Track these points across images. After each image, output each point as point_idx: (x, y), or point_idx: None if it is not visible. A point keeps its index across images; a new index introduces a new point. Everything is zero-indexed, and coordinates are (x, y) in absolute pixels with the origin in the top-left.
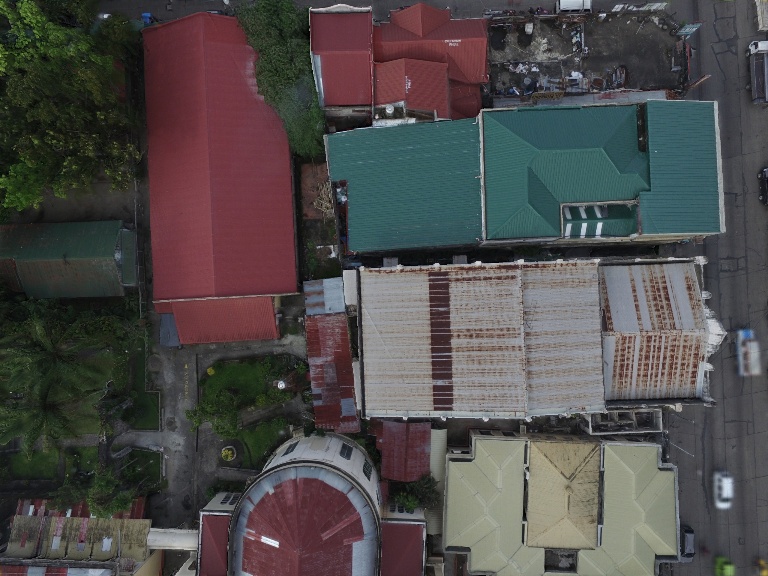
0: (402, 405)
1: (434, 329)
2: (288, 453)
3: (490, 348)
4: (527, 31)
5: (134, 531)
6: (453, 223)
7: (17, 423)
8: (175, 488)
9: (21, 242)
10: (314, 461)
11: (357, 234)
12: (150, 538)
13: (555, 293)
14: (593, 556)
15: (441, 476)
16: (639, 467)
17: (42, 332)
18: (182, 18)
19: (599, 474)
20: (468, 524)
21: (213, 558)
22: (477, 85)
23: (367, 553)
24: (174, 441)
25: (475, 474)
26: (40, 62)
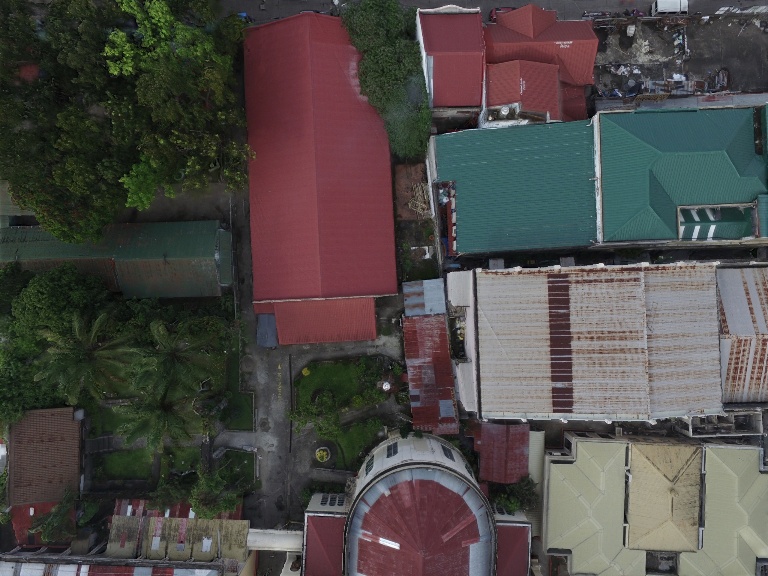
0: (520, 407)
1: (553, 331)
2: (393, 454)
3: (612, 350)
4: (629, 33)
5: (233, 532)
6: (566, 225)
7: (141, 423)
8: (268, 489)
9: (119, 242)
10: (430, 463)
11: (466, 235)
12: (250, 539)
13: (674, 296)
14: (695, 559)
15: (539, 478)
16: (742, 470)
17: (165, 332)
18: (287, 18)
19: (700, 477)
20: (571, 526)
21: (320, 559)
22: (583, 87)
23: (482, 555)
24: (267, 442)
25: (577, 476)
26: (164, 61)
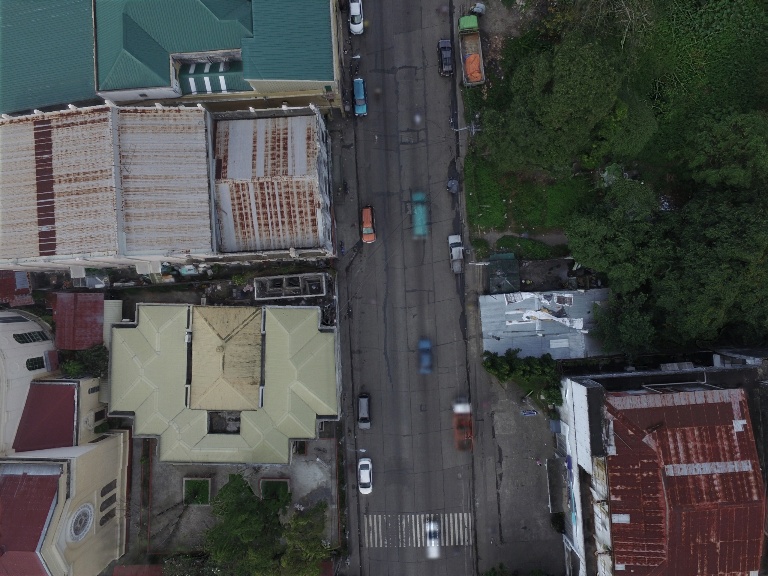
0: (13, 253)
1: (39, 176)
2: None
3: (86, 191)
4: None
5: None
6: (78, 80)
7: None
8: None
9: None
10: None
11: None
12: None
13: (157, 138)
14: (254, 417)
15: None
16: (295, 327)
17: None
18: None
19: (262, 337)
20: (127, 387)
21: None
22: None
23: None
24: None
25: (137, 339)
26: None
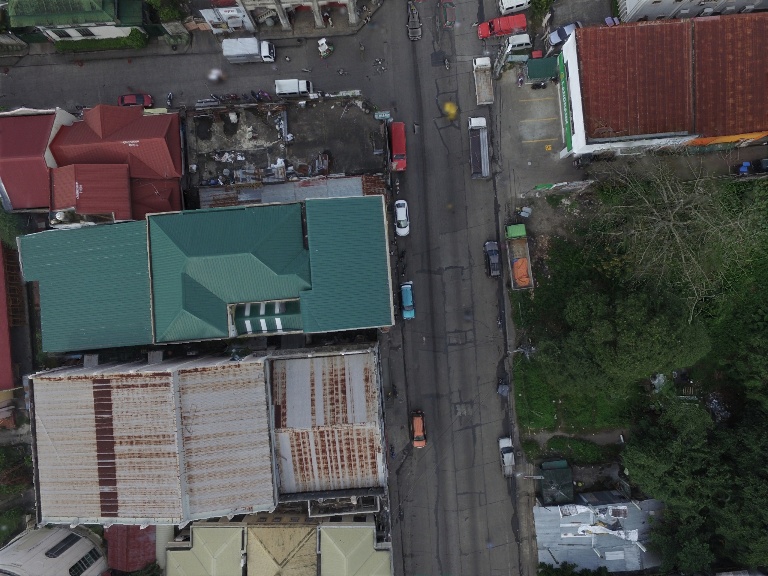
0: (73, 512)
1: (99, 436)
2: None
3: (148, 455)
4: (232, 120)
5: None
6: (133, 324)
7: None
8: None
9: None
10: None
11: (48, 335)
12: None
13: (217, 396)
14: None
15: None
16: (351, 550)
17: None
18: None
19: (317, 557)
20: None
21: None
22: (173, 179)
23: None
24: None
25: (192, 563)
26: None
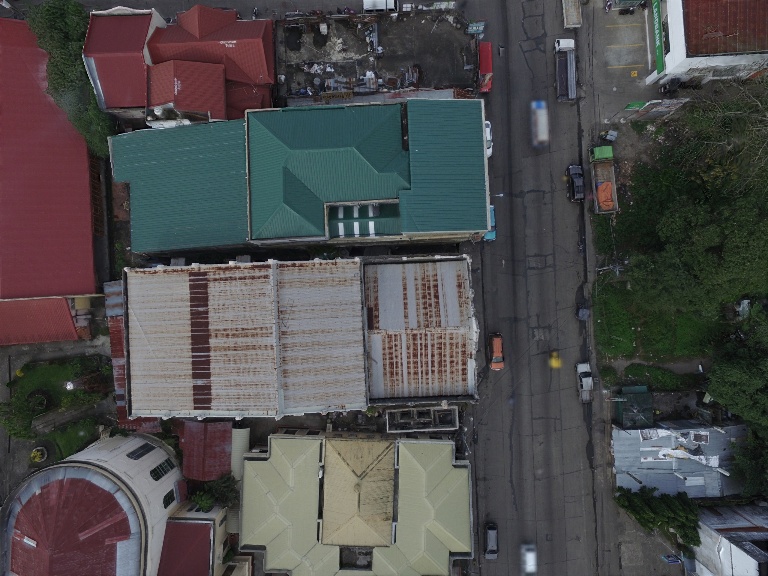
0: (165, 405)
1: (194, 329)
2: None
3: (245, 347)
4: (322, 31)
5: None
6: (226, 223)
7: None
8: None
9: None
10: (81, 461)
11: (138, 235)
12: None
13: (314, 292)
14: (387, 553)
15: None
16: (430, 464)
17: None
18: None
19: (395, 472)
20: (261, 522)
21: None
22: (264, 86)
23: (135, 552)
24: None
25: (269, 473)
26: None
